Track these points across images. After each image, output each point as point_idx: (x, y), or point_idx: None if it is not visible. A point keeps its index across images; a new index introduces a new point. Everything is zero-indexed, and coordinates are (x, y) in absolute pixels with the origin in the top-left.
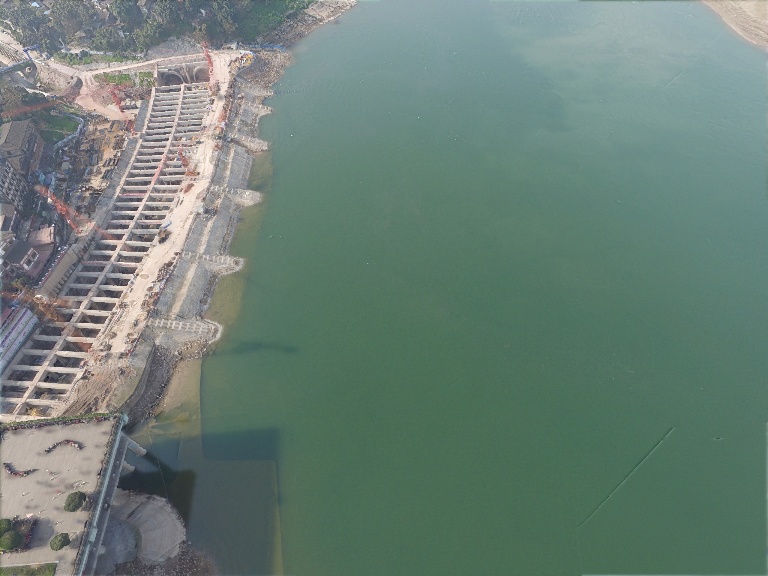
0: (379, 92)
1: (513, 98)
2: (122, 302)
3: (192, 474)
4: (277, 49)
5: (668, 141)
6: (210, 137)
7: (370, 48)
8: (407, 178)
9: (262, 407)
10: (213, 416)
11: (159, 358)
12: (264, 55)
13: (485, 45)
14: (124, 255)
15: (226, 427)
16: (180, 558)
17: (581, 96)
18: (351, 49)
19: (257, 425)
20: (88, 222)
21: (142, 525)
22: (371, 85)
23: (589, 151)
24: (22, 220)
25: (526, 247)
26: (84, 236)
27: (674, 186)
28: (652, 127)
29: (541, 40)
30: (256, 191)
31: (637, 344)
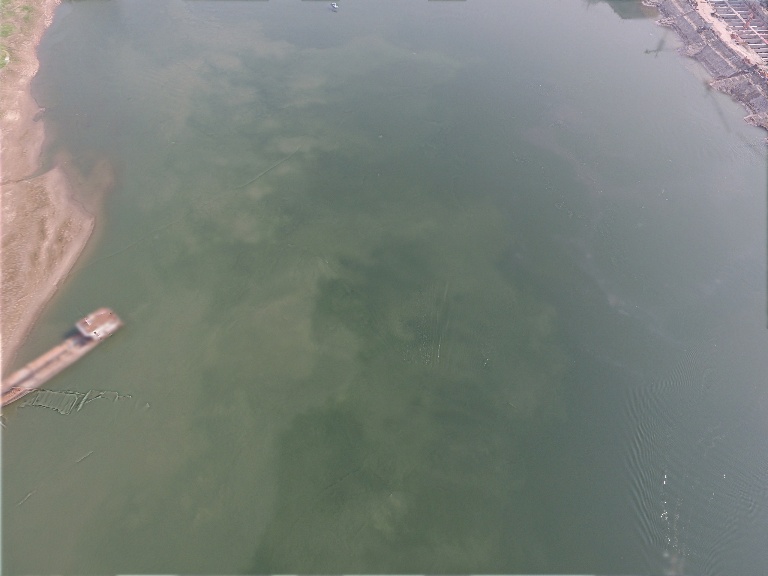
0: (640, 142)
1: None
2: None
3: None
4: None
5: (342, 96)
6: (765, 69)
7: (700, 227)
8: (574, 62)
9: None
10: None
11: None
12: None
13: (514, 226)
14: None
15: None
16: None
17: (411, 117)
18: (729, 223)
19: None
20: None
21: None
22: (655, 153)
23: (419, 87)
24: None
25: (486, 31)
26: (761, 7)
27: (369, 61)
28: (346, 109)
29: (425, 225)
30: (686, 56)
31: None
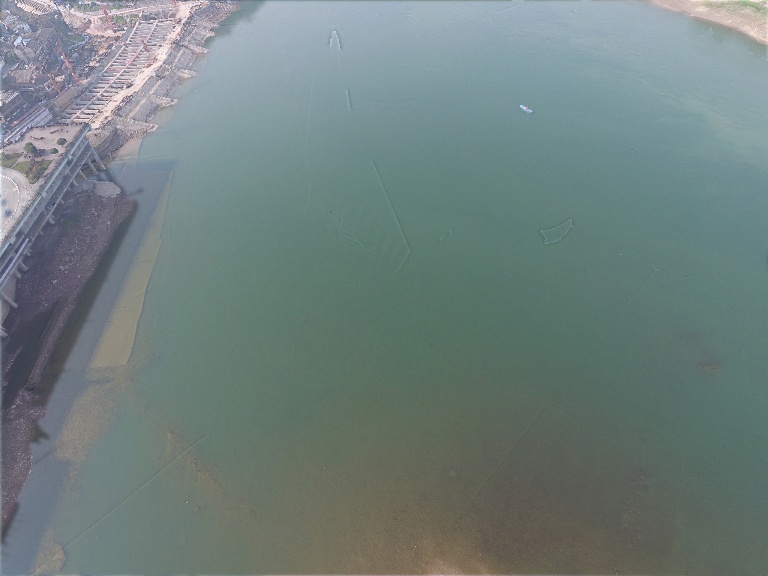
0: (292, 22)
1: (382, 21)
2: (100, 110)
3: (128, 176)
4: (229, 2)
5: (480, 41)
6: (168, 43)
7: None
8: (292, 62)
9: (172, 153)
10: (144, 157)
11: (118, 135)
12: (218, 4)
13: None
14: (105, 95)
15: (150, 160)
16: (116, 198)
17: (427, 17)
18: (281, 0)
19: (167, 159)
20: (85, 79)
21: (98, 183)
22: (288, 19)
23: (422, 47)
24: (46, 73)
25: (353, 90)
26: (82, 84)
27: (467, 61)
28: (473, 34)
29: None
30: (194, 71)
31: (394, 124)
